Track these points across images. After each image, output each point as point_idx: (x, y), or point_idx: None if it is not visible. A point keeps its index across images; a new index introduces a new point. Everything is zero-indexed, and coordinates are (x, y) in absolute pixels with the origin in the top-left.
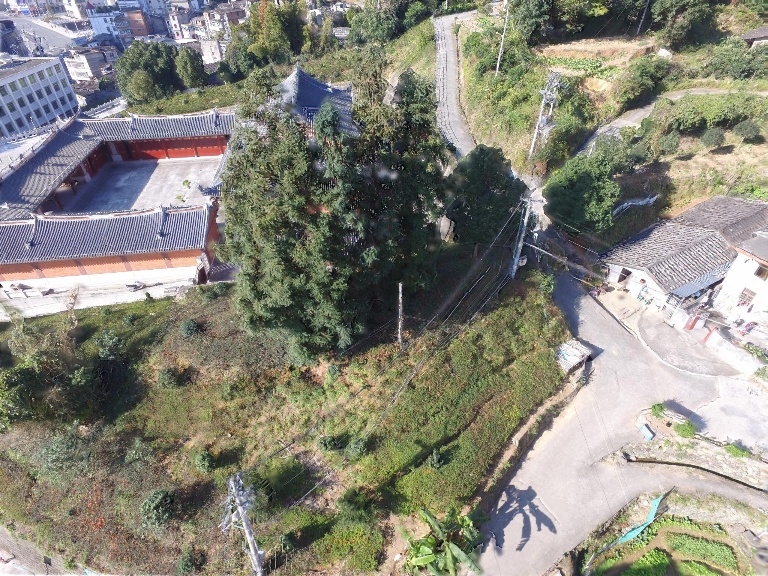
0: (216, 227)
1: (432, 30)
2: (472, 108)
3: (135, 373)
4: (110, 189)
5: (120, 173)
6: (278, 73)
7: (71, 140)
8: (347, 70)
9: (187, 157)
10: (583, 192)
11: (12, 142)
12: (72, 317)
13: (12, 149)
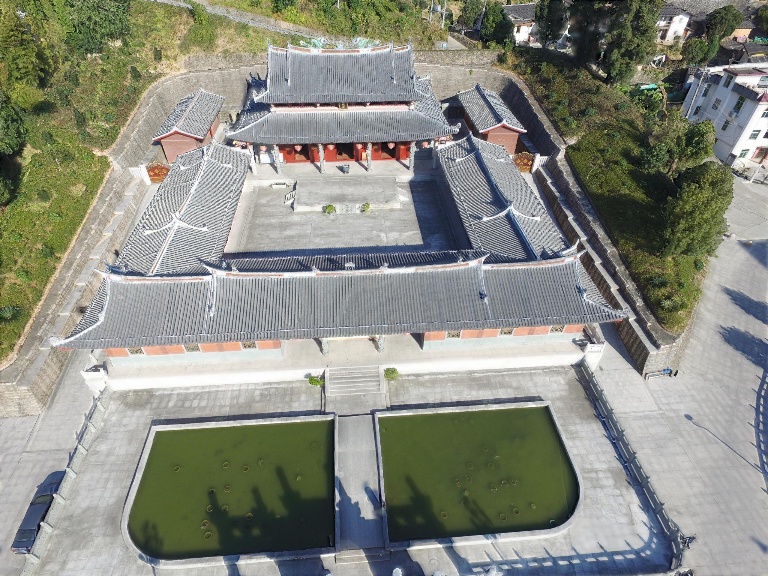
0: None
1: (173, 6)
2: (359, 32)
3: (647, 131)
4: None
5: None
6: (87, 115)
7: (239, 270)
8: (124, 82)
9: None
10: (508, 19)
11: None
12: (664, 103)
13: None
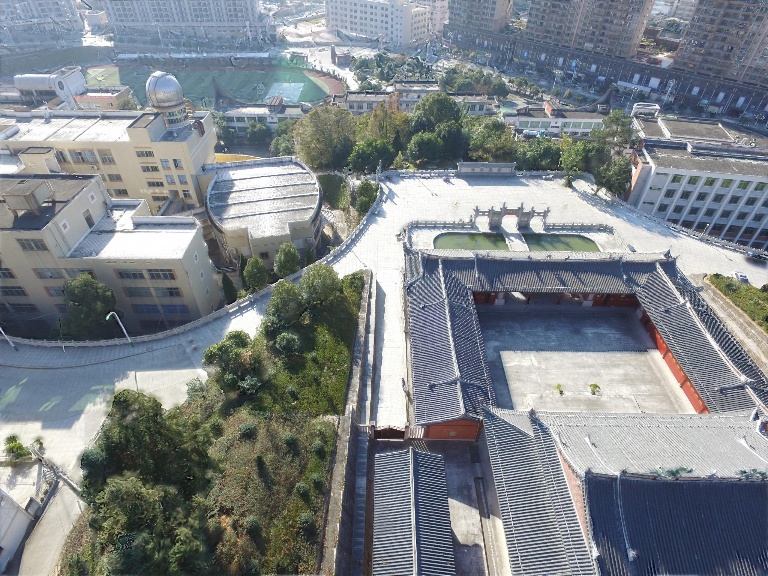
0: (476, 432)
1: None
2: None
3: None
4: (576, 325)
5: (613, 324)
6: None
7: (613, 273)
8: None
9: (674, 376)
10: None
11: (673, 229)
12: (248, 359)
13: (658, 234)
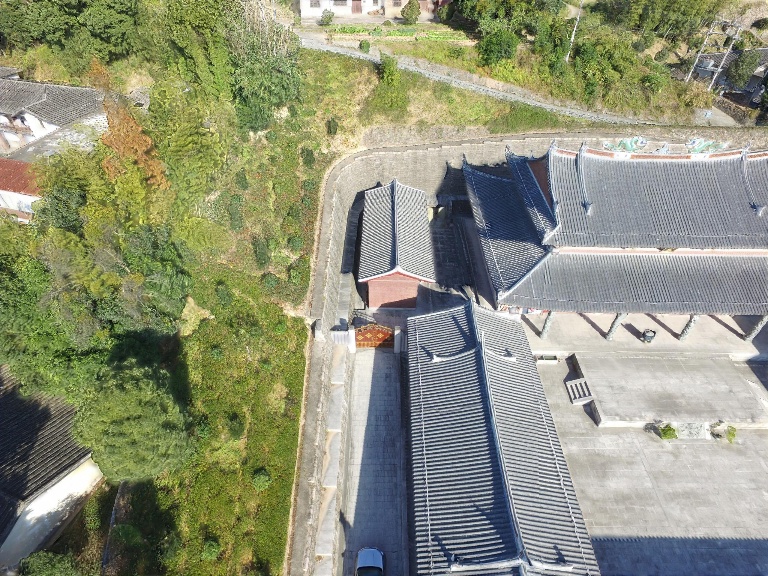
0: None
1: (352, 58)
2: None
3: None
4: None
5: None
6: (270, 245)
7: None
8: (296, 171)
9: None
10: None
11: None
12: None
13: None
